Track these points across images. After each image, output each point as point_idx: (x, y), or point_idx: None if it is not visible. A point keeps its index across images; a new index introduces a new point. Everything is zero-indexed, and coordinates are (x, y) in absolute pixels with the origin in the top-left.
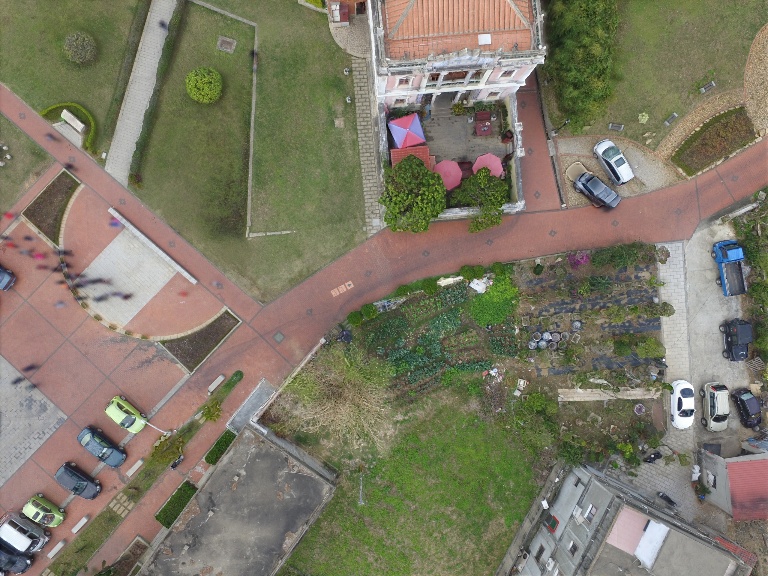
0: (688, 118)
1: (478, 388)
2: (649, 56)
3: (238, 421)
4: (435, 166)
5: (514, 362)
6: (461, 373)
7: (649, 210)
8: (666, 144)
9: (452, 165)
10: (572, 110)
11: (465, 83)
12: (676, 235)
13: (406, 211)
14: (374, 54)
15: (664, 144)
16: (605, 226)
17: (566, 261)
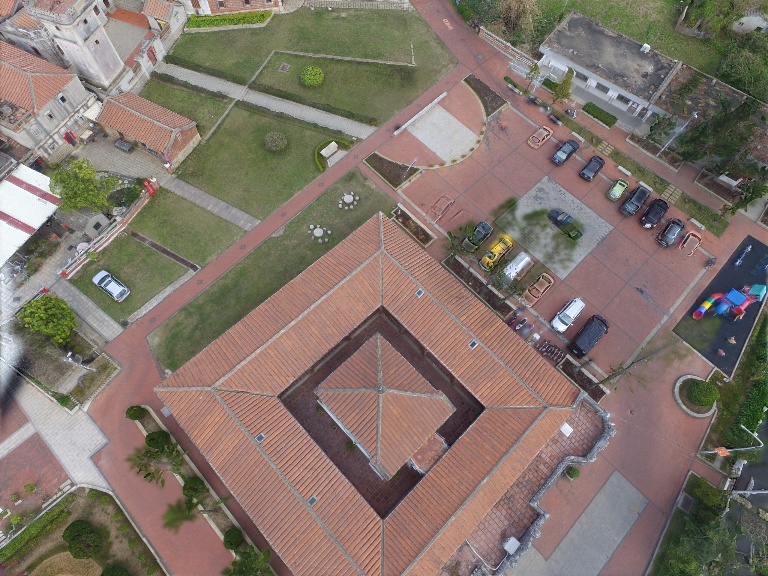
0: None
1: None
2: None
3: None
4: None
5: None
6: None
7: None
8: None
9: None
10: None
11: None
12: None
13: None
14: None
15: None
16: None
17: None
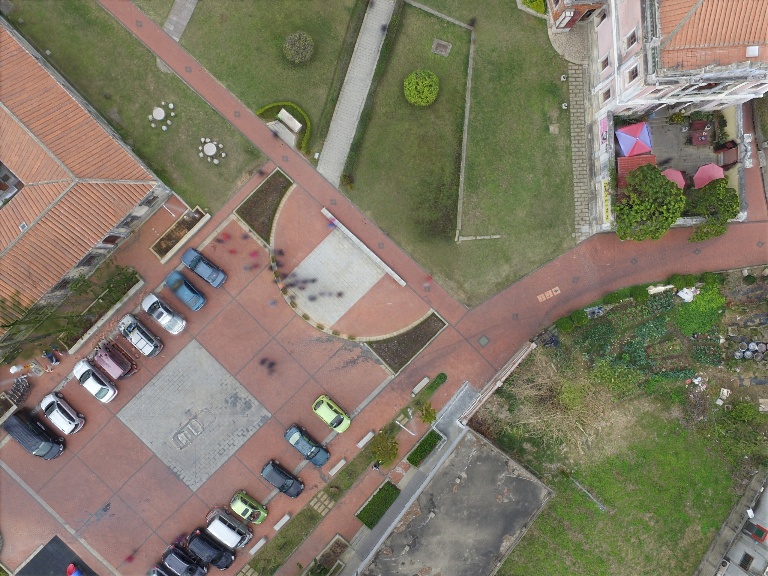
0: None
1: (682, 396)
2: None
3: (441, 423)
4: None
5: (717, 371)
6: (665, 381)
7: None
8: None
9: (676, 174)
10: None
11: (708, 94)
12: None
13: (647, 220)
14: (616, 62)
15: None
16: None
17: None
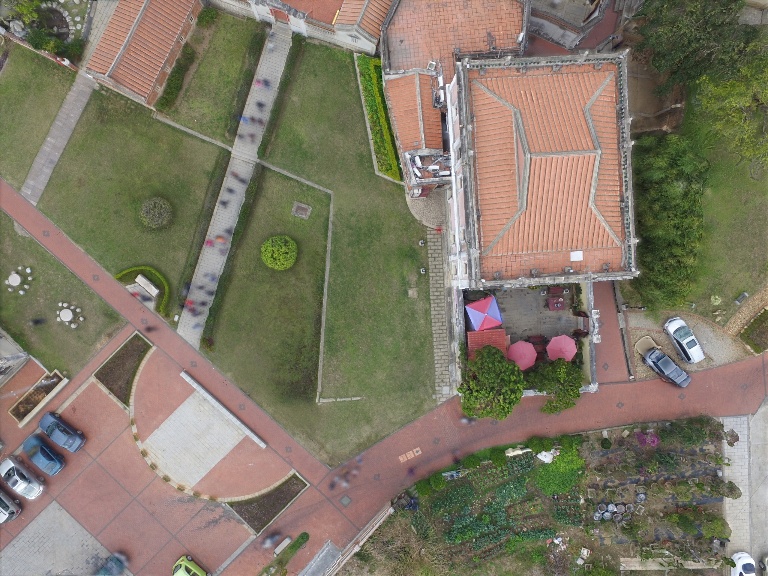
0: (758, 296)
1: (542, 557)
2: (722, 236)
3: None
4: (510, 347)
5: (578, 531)
6: (525, 541)
7: (716, 384)
8: (735, 321)
9: (527, 347)
10: (649, 298)
11: None
12: (741, 410)
13: (487, 406)
14: (458, 247)
15: (733, 321)
16: (672, 399)
17: (633, 434)
